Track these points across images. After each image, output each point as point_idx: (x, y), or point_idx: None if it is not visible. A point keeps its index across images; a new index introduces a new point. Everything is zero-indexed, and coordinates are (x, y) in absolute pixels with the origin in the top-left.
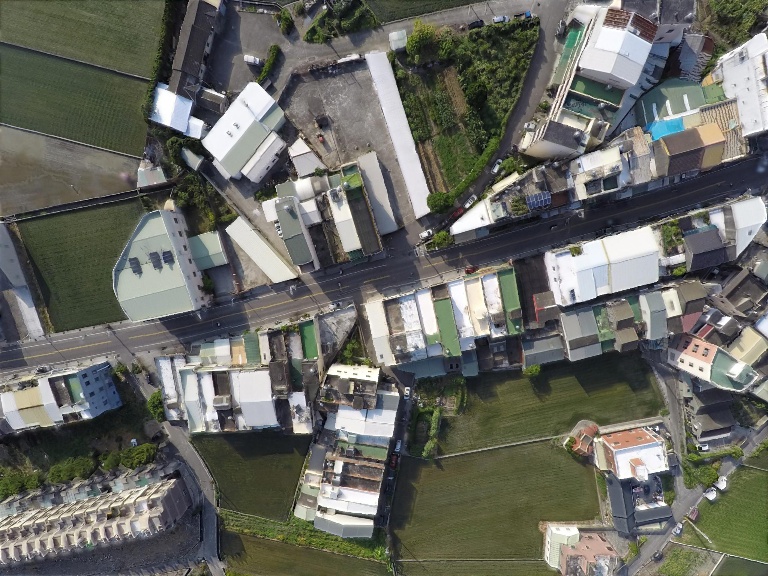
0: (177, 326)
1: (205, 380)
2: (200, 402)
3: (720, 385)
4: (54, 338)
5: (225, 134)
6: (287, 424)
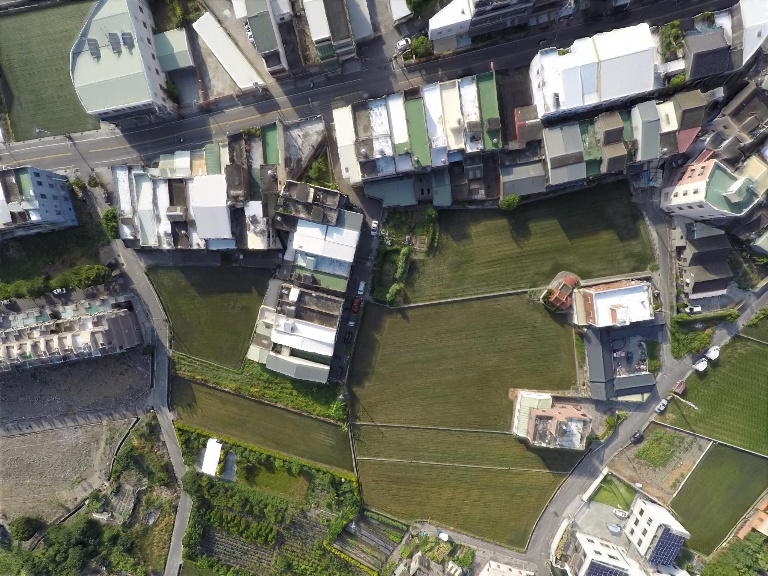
0: (139, 140)
1: (161, 189)
2: (154, 213)
3: (716, 207)
4: (14, 148)
5: None
6: (243, 244)
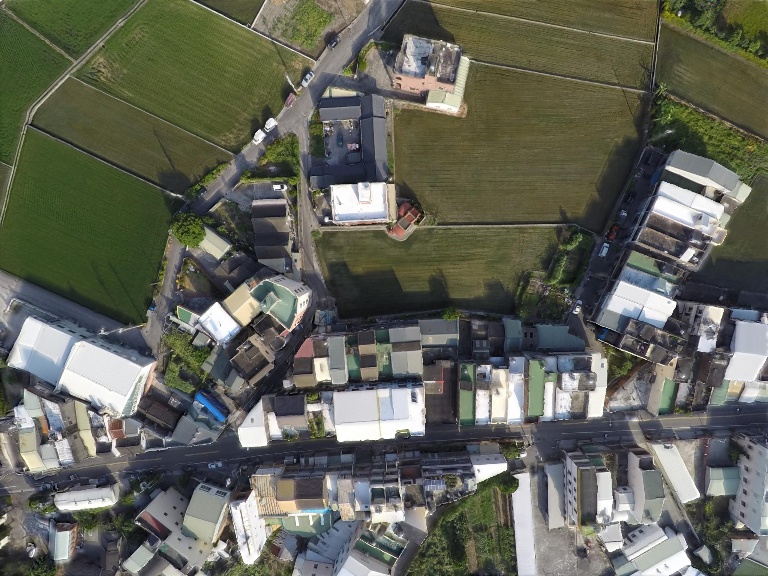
0: None
1: None
2: None
3: (287, 290)
4: None
5: (670, 567)
6: None
